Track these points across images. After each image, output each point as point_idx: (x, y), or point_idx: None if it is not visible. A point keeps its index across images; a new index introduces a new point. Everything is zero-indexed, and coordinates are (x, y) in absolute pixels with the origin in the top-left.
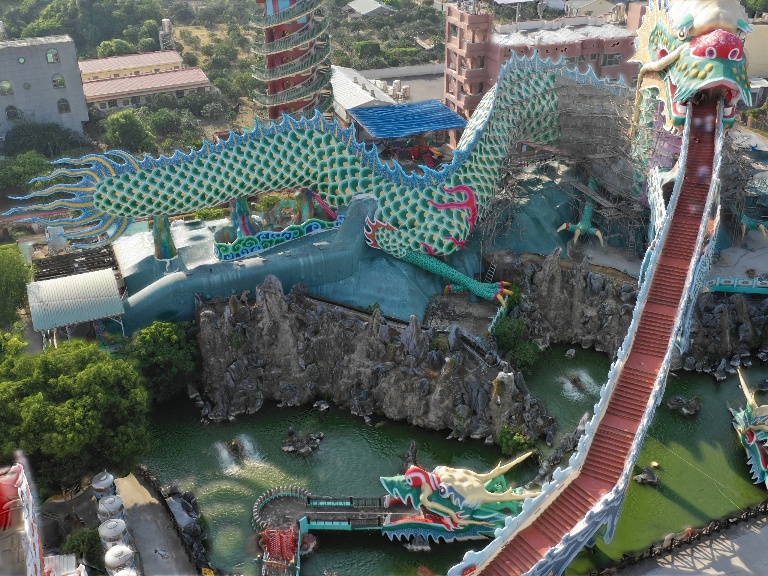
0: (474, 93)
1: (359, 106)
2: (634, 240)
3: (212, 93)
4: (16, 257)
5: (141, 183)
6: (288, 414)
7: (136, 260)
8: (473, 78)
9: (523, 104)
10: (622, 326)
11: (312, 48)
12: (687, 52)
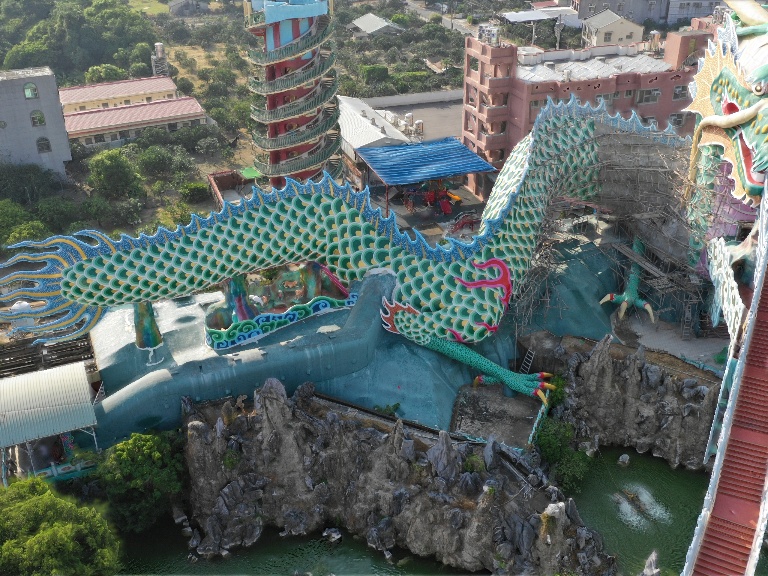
0: (495, 131)
1: (368, 144)
2: (690, 317)
3: (208, 126)
4: None
5: (117, 267)
6: (292, 545)
7: (114, 348)
8: (495, 117)
9: (560, 158)
10: (685, 429)
11: (318, 86)
12: (767, 111)
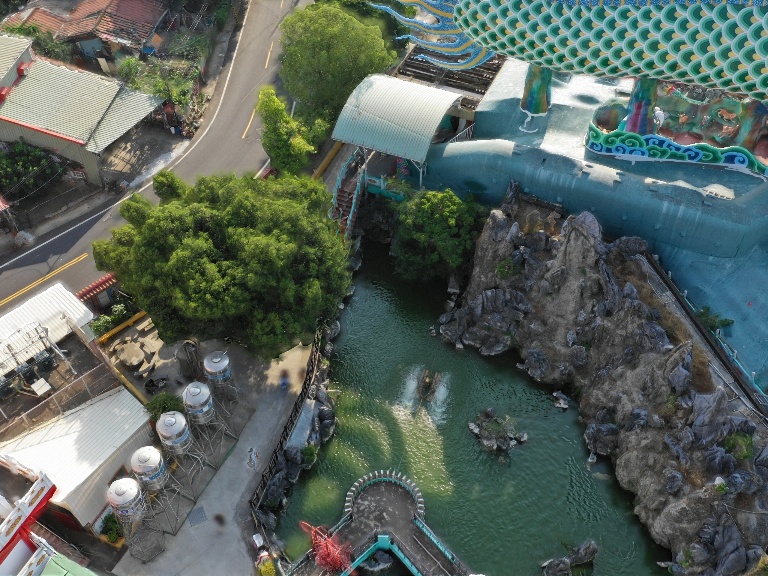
0: None
1: None
2: None
3: None
4: (370, 41)
5: (511, 13)
6: (520, 382)
7: (503, 95)
8: None
9: None
10: None
11: None
12: None
